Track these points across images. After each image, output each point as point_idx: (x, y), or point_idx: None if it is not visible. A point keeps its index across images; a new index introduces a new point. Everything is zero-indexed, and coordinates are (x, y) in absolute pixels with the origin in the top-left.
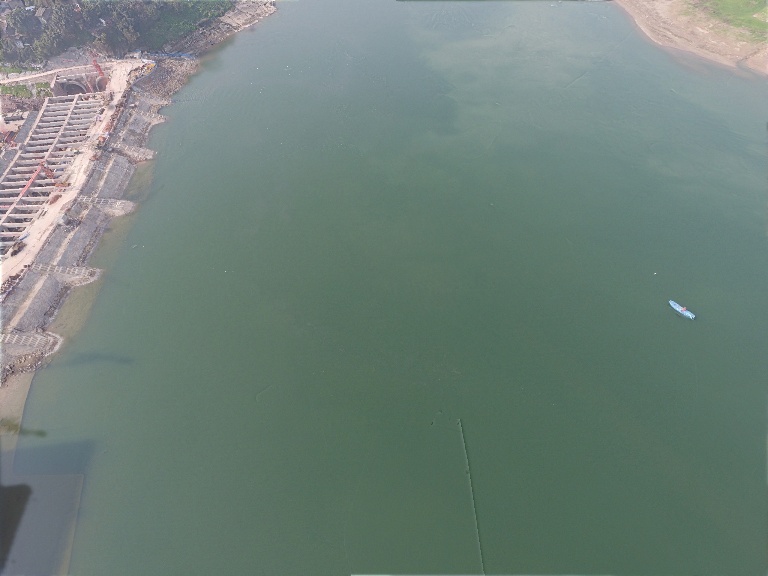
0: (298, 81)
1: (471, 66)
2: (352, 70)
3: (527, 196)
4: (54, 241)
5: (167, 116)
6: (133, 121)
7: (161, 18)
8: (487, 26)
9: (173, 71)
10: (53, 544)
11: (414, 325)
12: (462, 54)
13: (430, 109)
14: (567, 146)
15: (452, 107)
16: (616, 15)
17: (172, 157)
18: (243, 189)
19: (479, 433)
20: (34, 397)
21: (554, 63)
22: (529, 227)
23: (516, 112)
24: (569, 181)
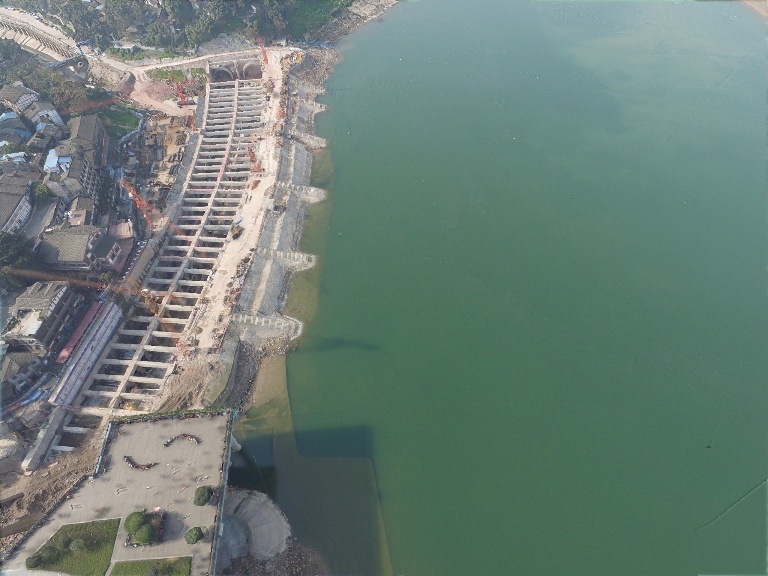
0: (446, 73)
1: (616, 62)
2: (497, 63)
3: (718, 195)
4: (268, 226)
5: (326, 105)
6: (299, 109)
7: (299, 6)
8: (616, 22)
9: (319, 60)
10: (365, 525)
11: (656, 321)
12: (602, 50)
13: (593, 105)
14: (741, 146)
15: (614, 103)
16: (747, 14)
17: (344, 146)
18: (429, 180)
19: (748, 432)
20: (294, 380)
21: (697, 62)
22: (732, 227)
23: (683, 110)
24: (756, 181)
